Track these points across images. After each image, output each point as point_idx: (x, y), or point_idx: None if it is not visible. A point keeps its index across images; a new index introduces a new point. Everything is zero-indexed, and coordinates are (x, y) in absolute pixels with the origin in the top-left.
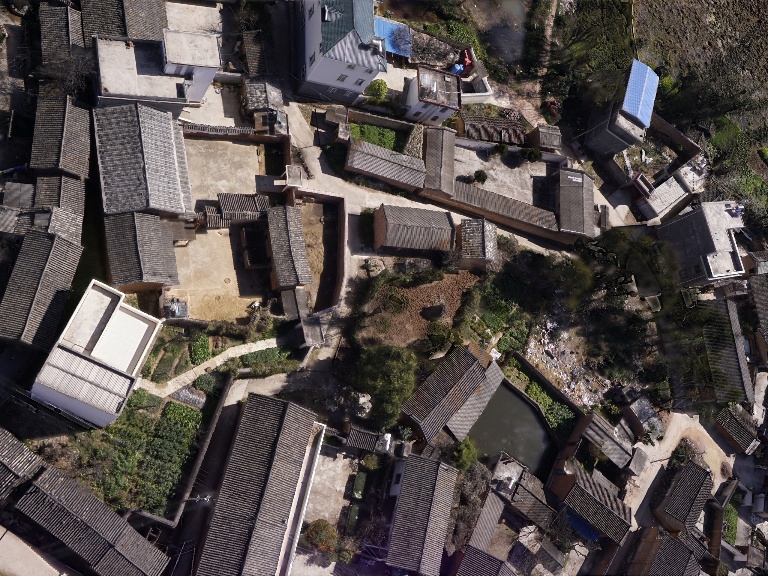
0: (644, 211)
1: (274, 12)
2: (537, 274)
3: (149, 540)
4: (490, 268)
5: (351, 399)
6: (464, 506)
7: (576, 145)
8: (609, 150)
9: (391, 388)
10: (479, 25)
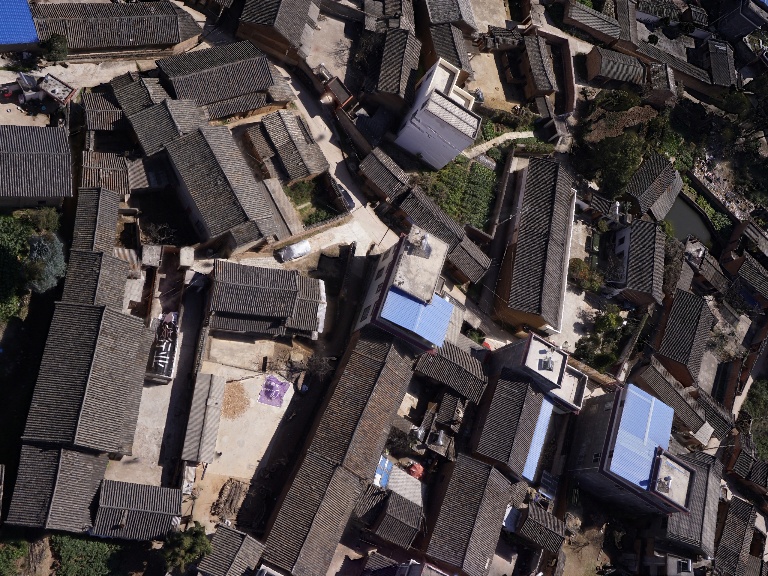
0: None
1: None
2: (697, 117)
3: None
4: (668, 104)
5: (583, 183)
6: (669, 265)
7: (713, 29)
8: (739, 33)
9: (626, 161)
10: None
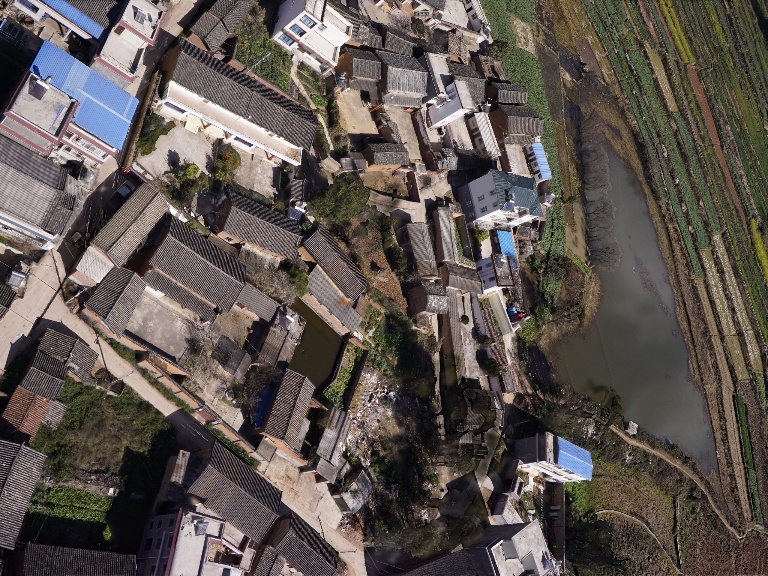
0: (498, 507)
1: None
2: None
3: (218, 50)
4: (418, 317)
5: None
6: None
7: (511, 429)
8: (523, 457)
9: None
10: (540, 343)
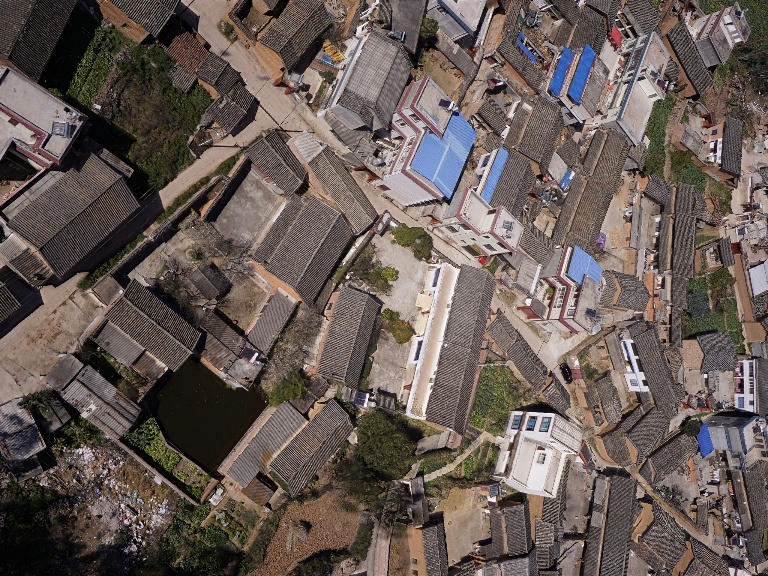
0: None
1: None
2: None
3: None
4: None
5: None
6: None
7: None
8: None
9: None
10: None
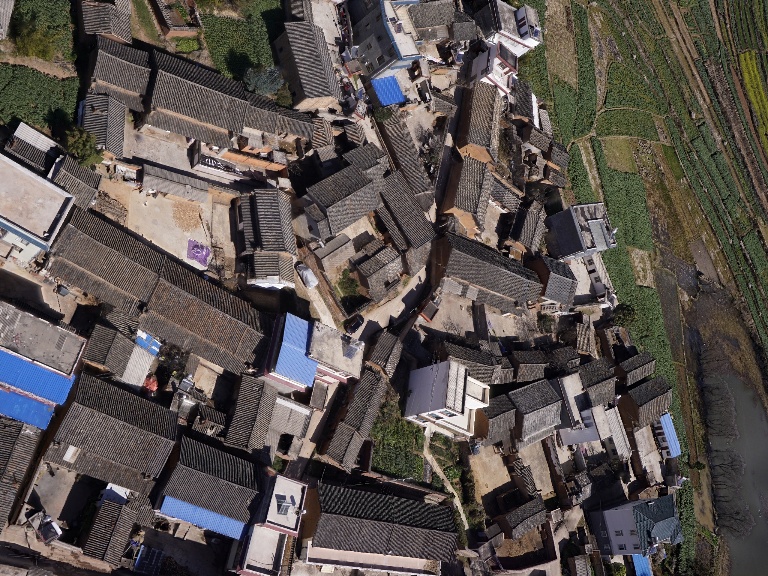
0: None
1: (617, 487)
2: None
3: None
4: None
5: None
6: None
7: None
8: None
9: None
10: None
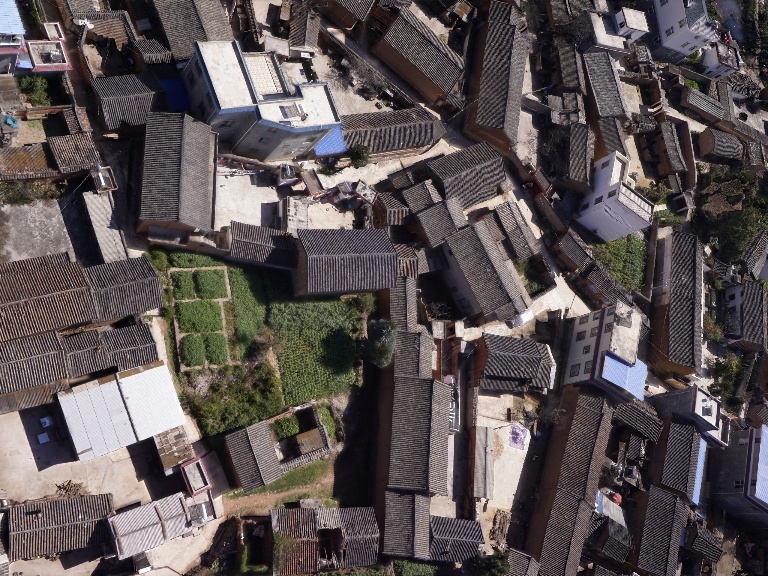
0: None
1: None
2: None
3: None
4: (758, 175)
5: None
6: (767, 317)
7: None
8: None
9: (745, 233)
10: (720, 17)
